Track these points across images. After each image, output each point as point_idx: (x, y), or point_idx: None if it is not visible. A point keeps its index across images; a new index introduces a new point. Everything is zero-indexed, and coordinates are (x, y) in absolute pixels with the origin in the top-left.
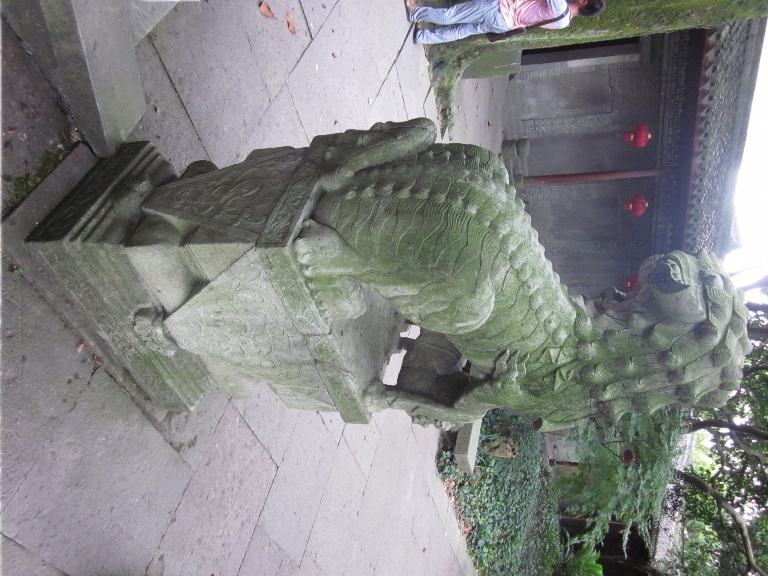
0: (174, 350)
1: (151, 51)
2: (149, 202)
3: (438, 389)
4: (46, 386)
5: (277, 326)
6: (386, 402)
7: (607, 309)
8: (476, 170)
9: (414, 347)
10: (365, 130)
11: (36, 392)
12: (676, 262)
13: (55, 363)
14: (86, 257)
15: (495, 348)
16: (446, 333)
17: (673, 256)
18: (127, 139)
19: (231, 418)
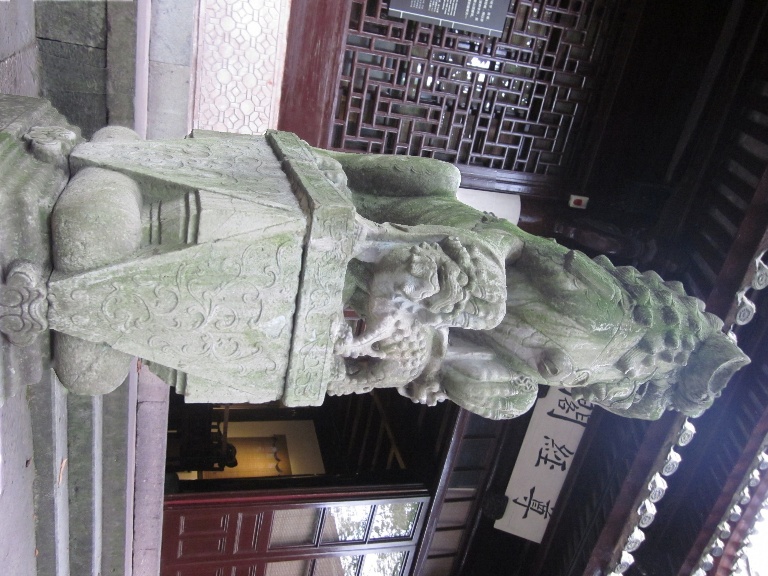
0: (59, 151)
1: None
2: None
3: None
4: None
5: (253, 158)
6: (372, 223)
7: None
8: None
9: None
10: None
11: None
12: None
13: None
14: (54, 112)
15: (476, 214)
16: (432, 167)
17: None
18: None
19: None
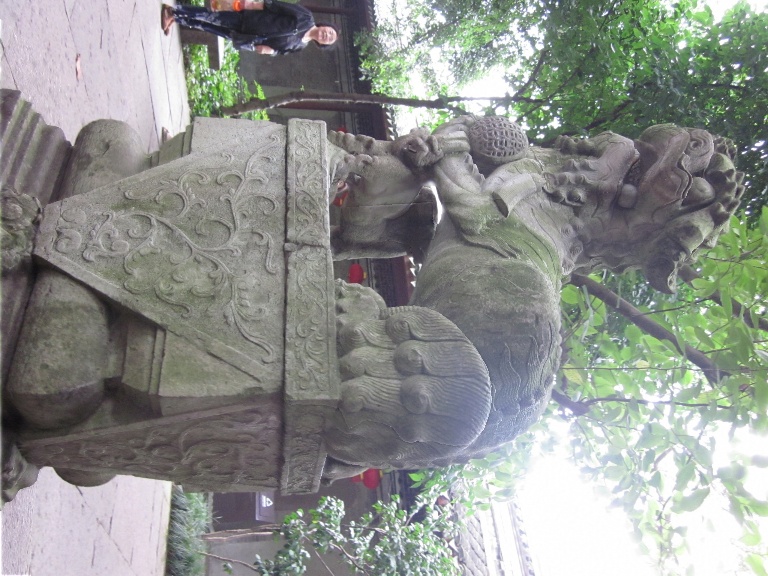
0: None
1: None
2: (42, 461)
3: (389, 236)
4: None
5: None
6: None
7: (593, 253)
8: (526, 419)
9: (361, 209)
10: (382, 410)
11: None
12: (686, 255)
13: None
14: None
15: None
16: None
17: (689, 251)
18: None
19: (14, 53)
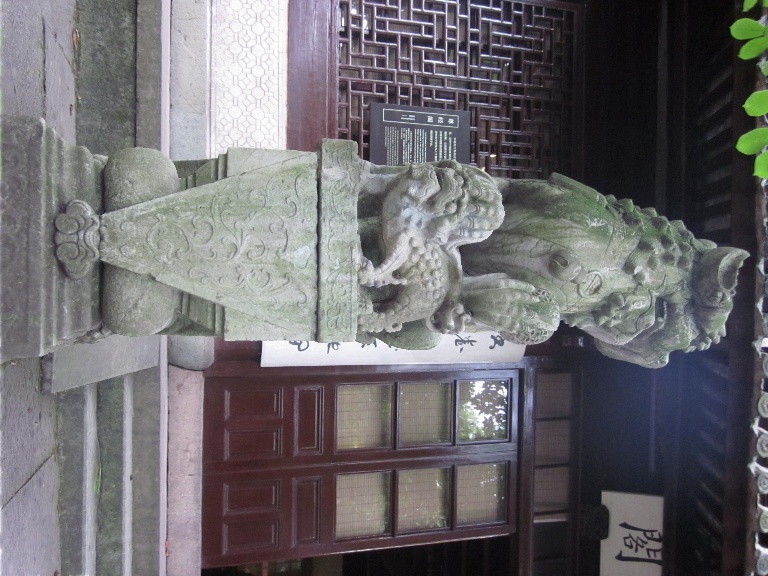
0: None
1: (50, 448)
2: None
3: None
4: (1, 73)
5: None
6: None
7: None
8: None
9: None
10: None
11: (3, 63)
12: None
13: (3, 102)
14: None
15: None
16: None
17: None
18: (36, 360)
19: None
